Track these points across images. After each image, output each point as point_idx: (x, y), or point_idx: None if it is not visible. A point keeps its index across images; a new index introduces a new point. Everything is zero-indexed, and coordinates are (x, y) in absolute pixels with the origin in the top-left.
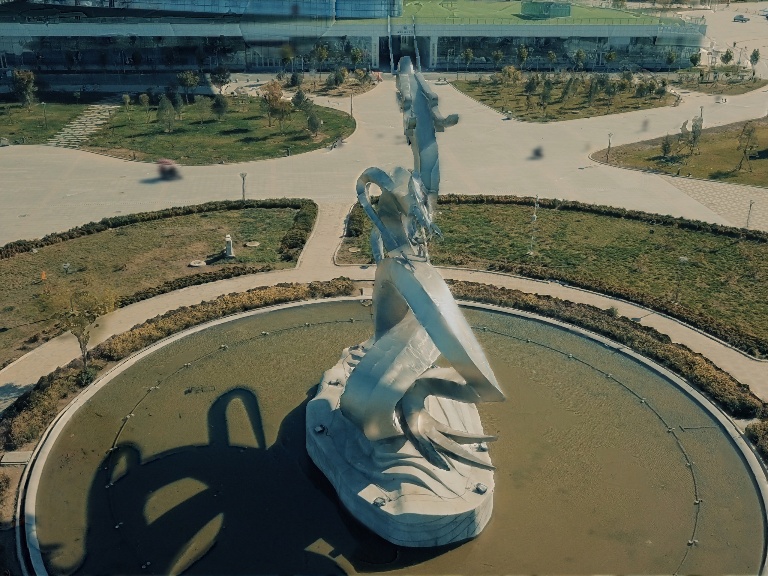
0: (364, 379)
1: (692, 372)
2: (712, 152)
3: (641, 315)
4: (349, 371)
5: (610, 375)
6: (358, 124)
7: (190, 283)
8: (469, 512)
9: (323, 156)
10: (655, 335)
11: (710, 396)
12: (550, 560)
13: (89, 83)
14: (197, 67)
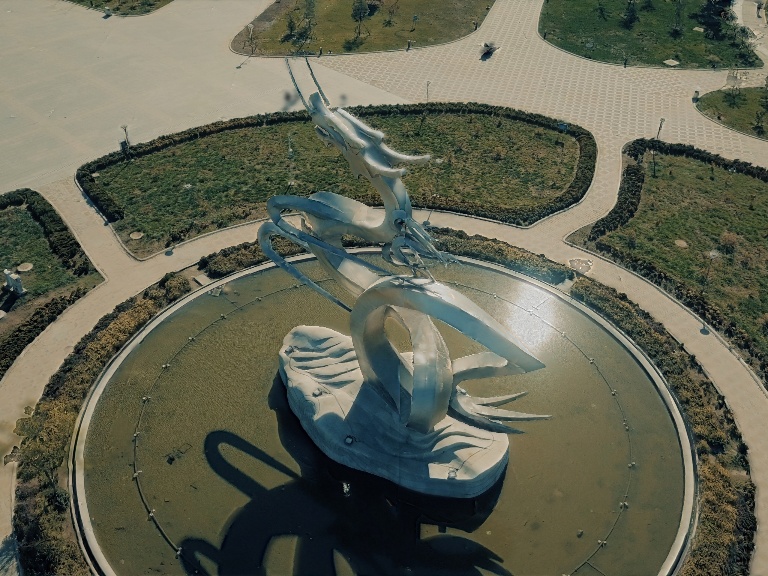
0: (424, 394)
1: (506, 258)
2: (323, 19)
3: (426, 217)
4: (313, 376)
5: (457, 283)
6: None
7: (24, 344)
8: None
9: None
10: (456, 234)
11: (530, 273)
12: (559, 451)
13: None
14: None
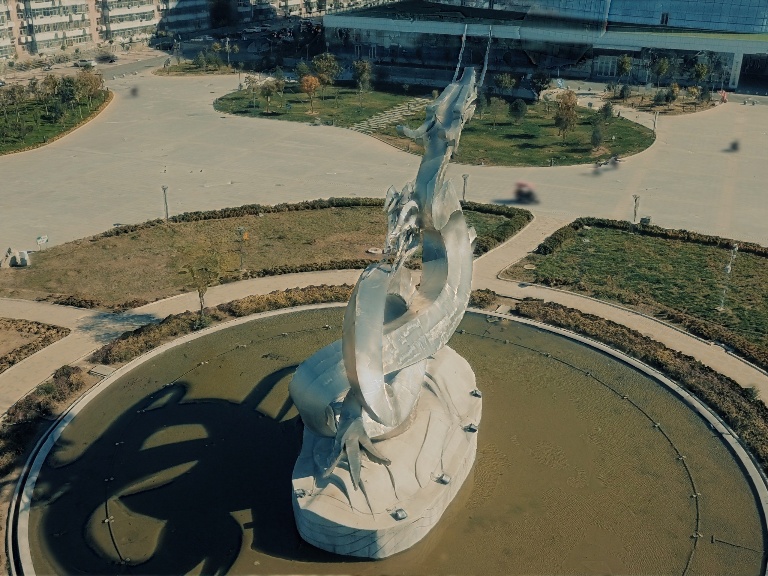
0: (308, 372)
1: None
2: None
3: None
4: None
5: (682, 457)
6: (654, 144)
7: (350, 266)
8: (369, 531)
9: (586, 171)
10: None
11: None
12: None
13: (430, 78)
14: (532, 71)
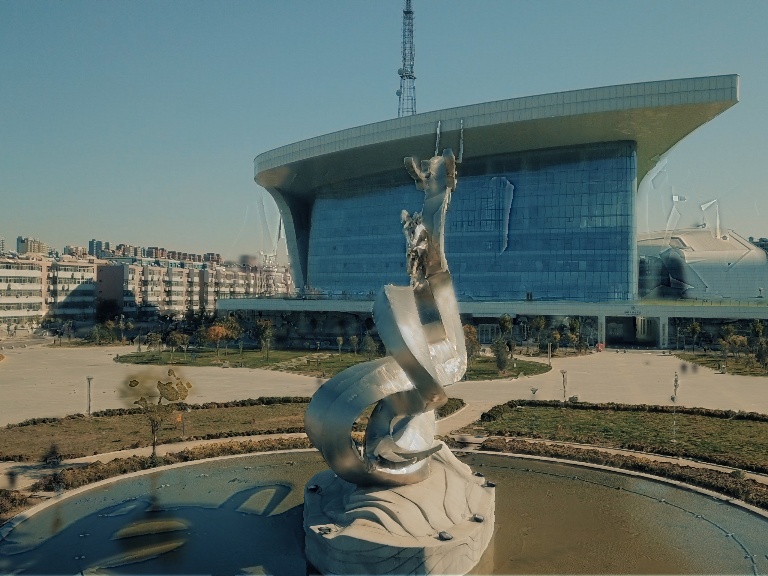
0: (328, 394)
1: None
2: None
3: None
4: None
5: (701, 515)
6: (553, 370)
7: (299, 430)
8: (416, 549)
9: (500, 383)
10: None
11: None
12: None
13: None
14: None
